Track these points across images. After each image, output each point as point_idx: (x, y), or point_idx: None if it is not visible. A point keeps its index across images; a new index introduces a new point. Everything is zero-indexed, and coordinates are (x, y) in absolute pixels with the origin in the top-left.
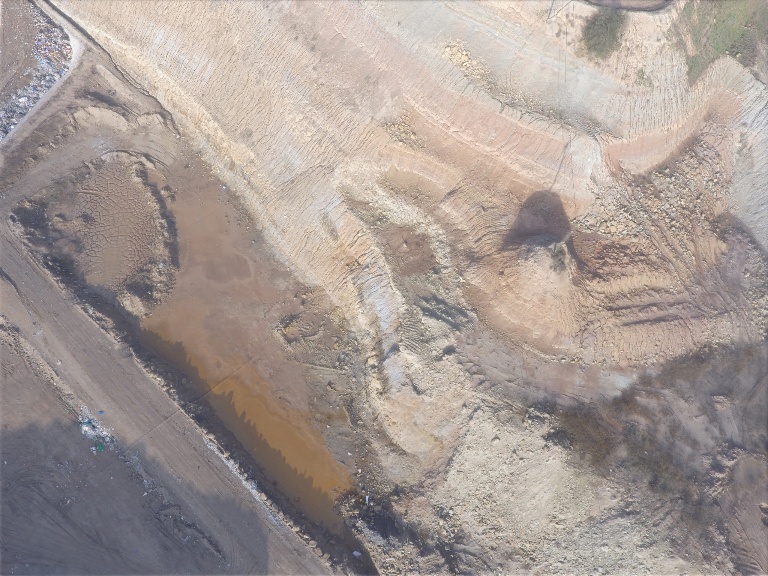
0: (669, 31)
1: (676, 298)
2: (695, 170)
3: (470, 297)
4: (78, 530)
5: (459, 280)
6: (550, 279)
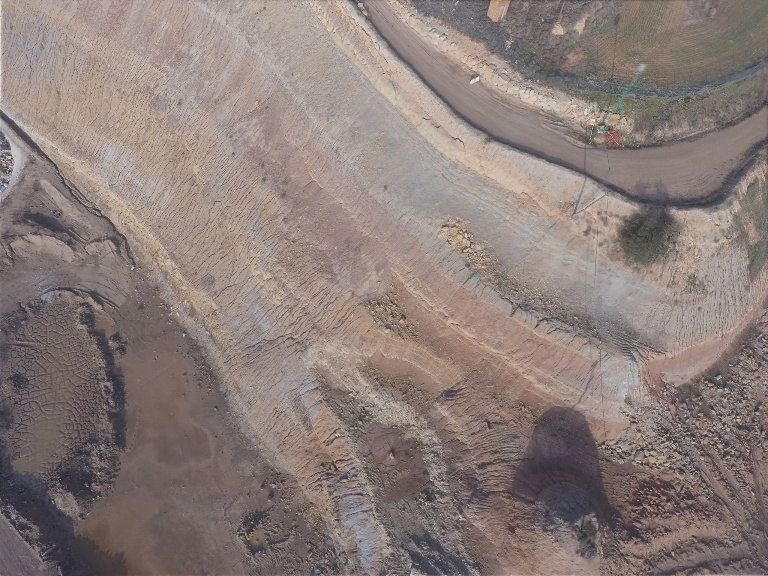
0: (729, 227)
1: (732, 552)
2: (753, 374)
3: (471, 545)
4: None
5: (458, 518)
6: (575, 561)
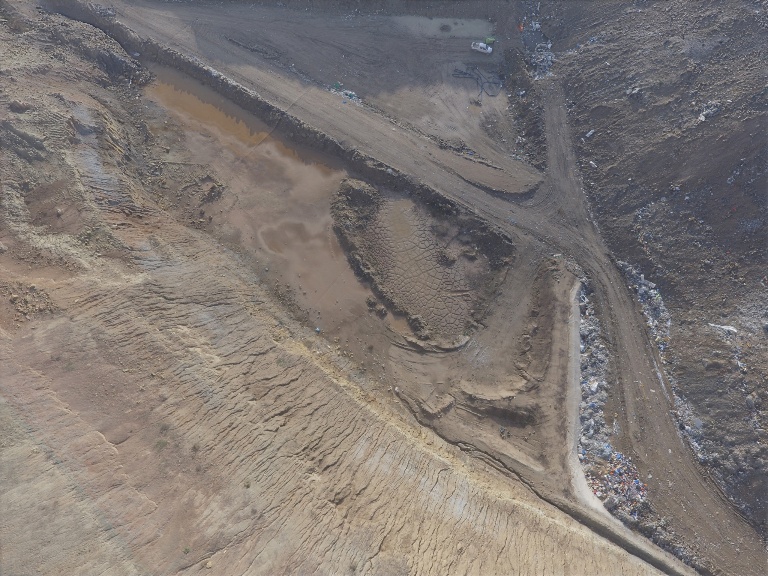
0: None
1: None
2: None
3: None
4: (330, 44)
5: None
6: None
